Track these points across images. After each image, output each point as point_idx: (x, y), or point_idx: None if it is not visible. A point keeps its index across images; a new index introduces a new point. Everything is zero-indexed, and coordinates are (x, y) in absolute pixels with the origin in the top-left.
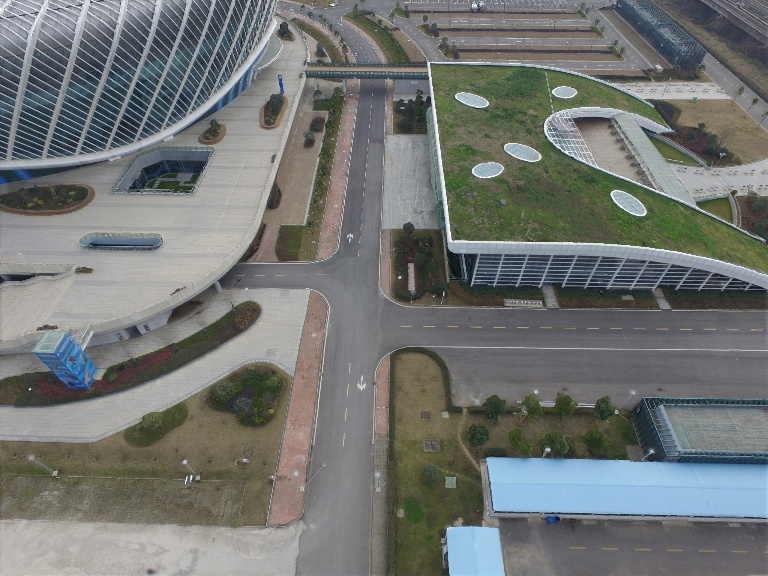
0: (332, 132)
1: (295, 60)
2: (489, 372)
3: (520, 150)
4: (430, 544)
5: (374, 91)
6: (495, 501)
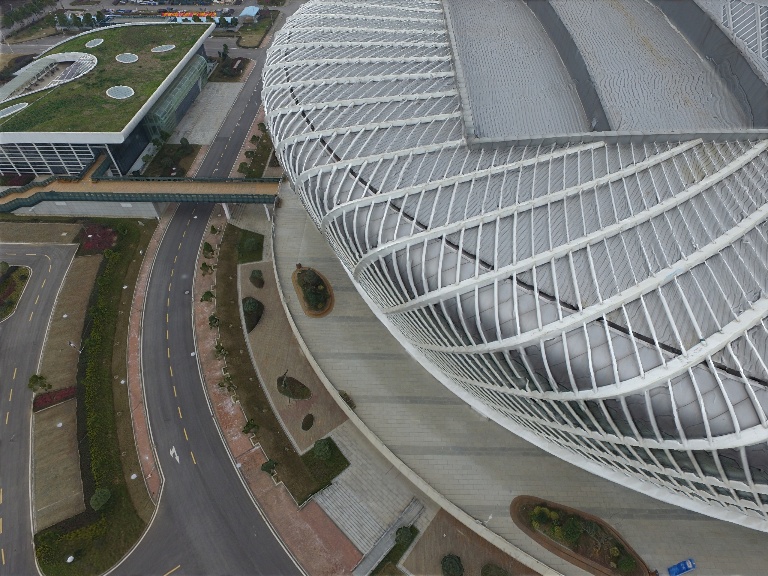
0: (263, 148)
1: (295, 212)
2: (219, 43)
3: (127, 58)
4: (260, 23)
5: (194, 206)
6: (237, 17)
